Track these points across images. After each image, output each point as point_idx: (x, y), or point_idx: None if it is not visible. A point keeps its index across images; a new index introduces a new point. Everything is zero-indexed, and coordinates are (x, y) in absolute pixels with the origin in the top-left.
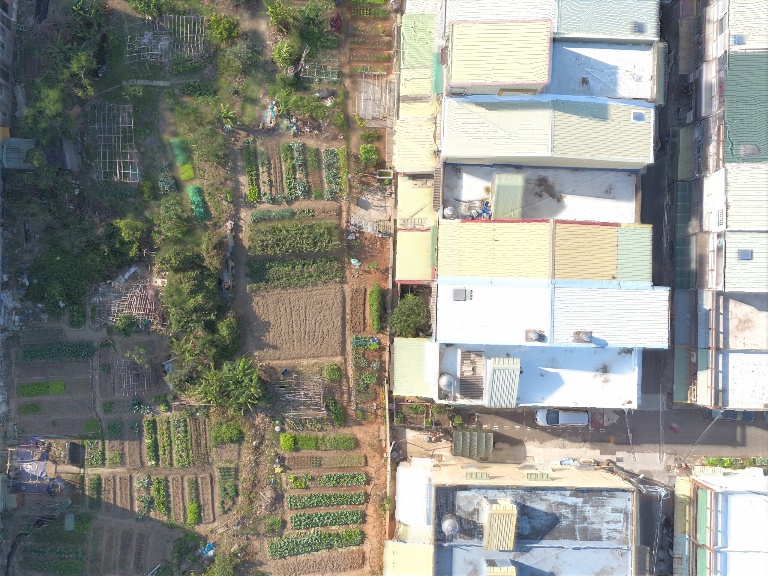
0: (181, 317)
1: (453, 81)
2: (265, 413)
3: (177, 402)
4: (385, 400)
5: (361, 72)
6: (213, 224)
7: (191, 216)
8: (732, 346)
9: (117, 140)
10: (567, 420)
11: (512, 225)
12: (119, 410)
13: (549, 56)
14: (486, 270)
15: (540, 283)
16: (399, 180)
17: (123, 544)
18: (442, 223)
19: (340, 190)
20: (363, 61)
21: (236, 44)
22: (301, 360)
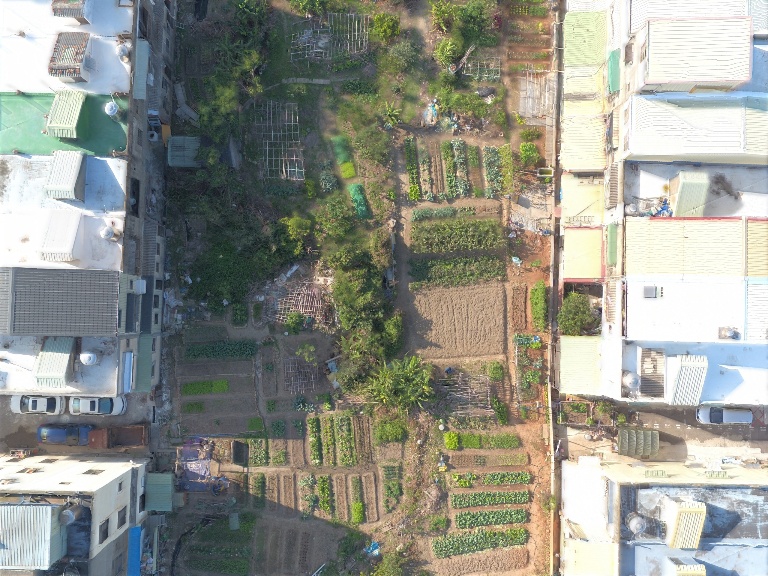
0: (351, 315)
1: (649, 78)
2: (429, 411)
3: (341, 400)
4: (548, 398)
5: (525, 70)
6: (374, 222)
7: None
8: None
9: (283, 138)
10: (731, 418)
11: (702, 222)
12: (282, 408)
13: (750, 53)
14: (676, 267)
15: (733, 280)
16: (564, 178)
17: (288, 543)
18: (629, 220)
19: (501, 188)
20: (522, 59)
21: (397, 42)
22: (463, 358)
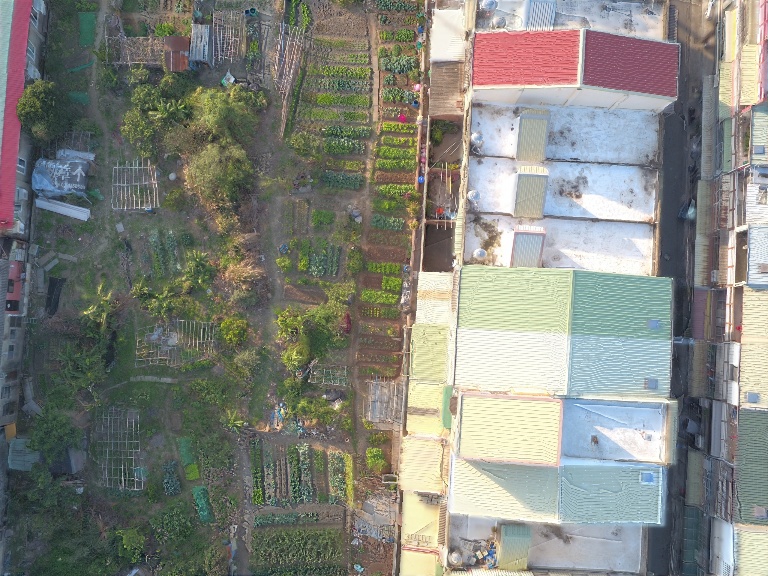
0: None
1: (461, 453)
2: None
3: None
4: None
5: (369, 382)
6: (216, 526)
7: (194, 517)
8: None
9: (123, 447)
10: None
11: None
12: None
13: (558, 439)
14: None
15: None
16: (404, 493)
17: None
18: None
19: (345, 495)
20: (371, 362)
21: (245, 345)
22: None
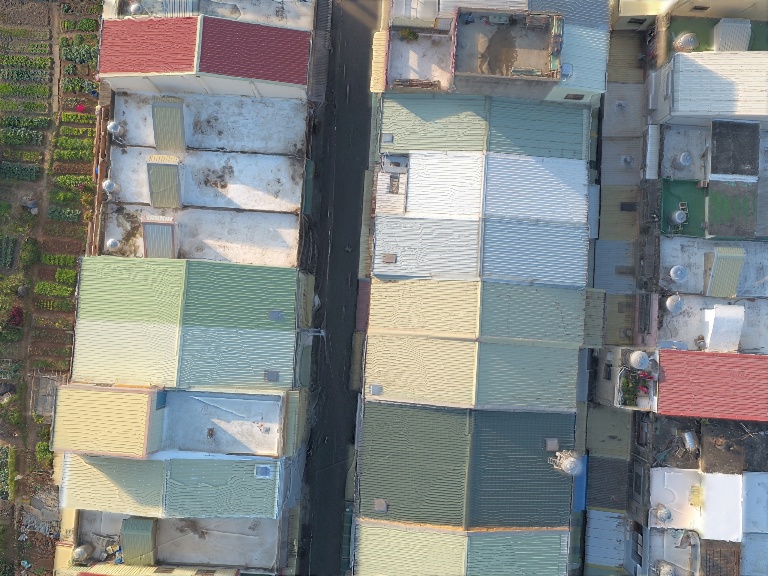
0: None
1: (55, 446)
2: None
3: None
4: None
5: (31, 375)
6: None
7: None
8: None
9: None
10: None
11: None
12: None
13: (144, 431)
14: None
15: None
16: None
17: None
18: (59, 574)
19: None
20: (44, 355)
21: None
22: None
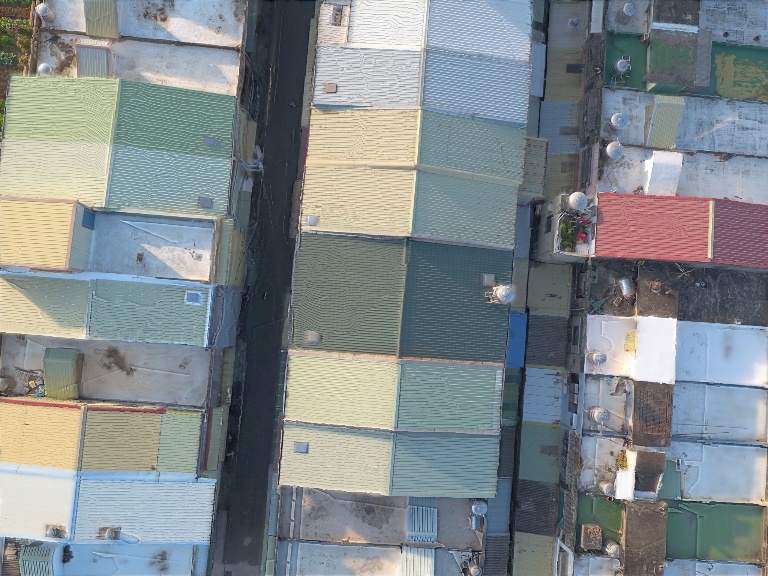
0: None
1: None
2: None
3: None
4: None
5: None
6: None
7: None
8: (303, 535)
9: None
10: None
11: (44, 409)
12: None
13: (68, 241)
14: (15, 455)
15: (66, 474)
16: None
17: None
18: None
19: None
20: None
21: None
22: None
